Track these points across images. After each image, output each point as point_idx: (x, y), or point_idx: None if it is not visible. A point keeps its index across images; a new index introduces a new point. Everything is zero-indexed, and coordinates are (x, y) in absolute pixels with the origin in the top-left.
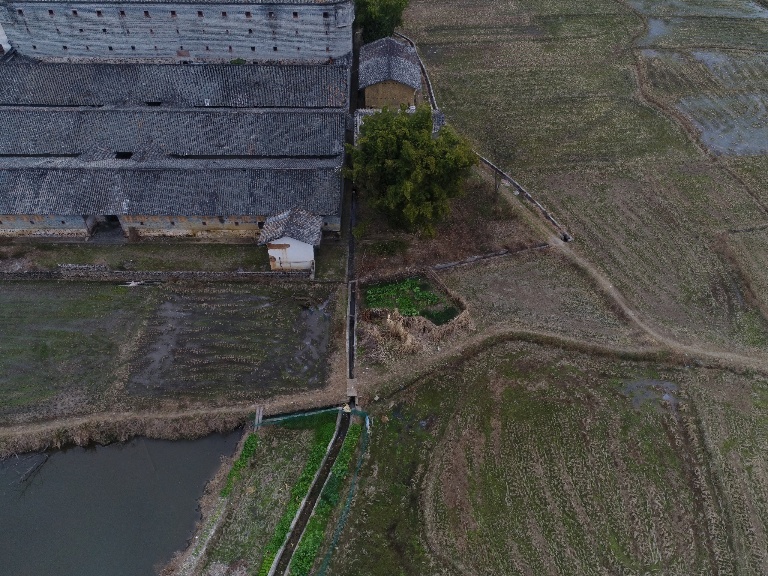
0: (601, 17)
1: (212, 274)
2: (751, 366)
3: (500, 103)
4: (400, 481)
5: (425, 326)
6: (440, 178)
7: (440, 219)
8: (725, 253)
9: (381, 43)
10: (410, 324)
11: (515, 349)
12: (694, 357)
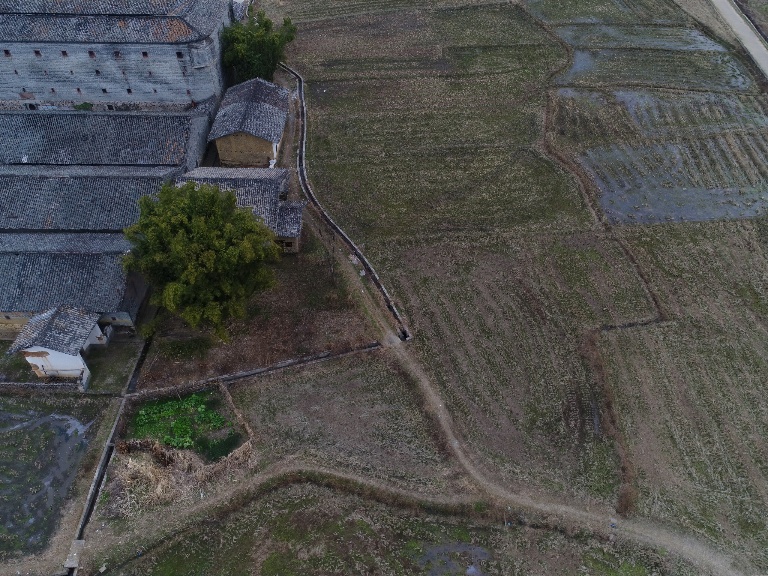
0: (523, 49)
1: None
2: (587, 526)
3: (379, 155)
4: None
5: (190, 464)
6: (235, 271)
7: (259, 310)
8: (591, 359)
9: (248, 85)
10: (174, 461)
11: (300, 495)
12: (518, 512)
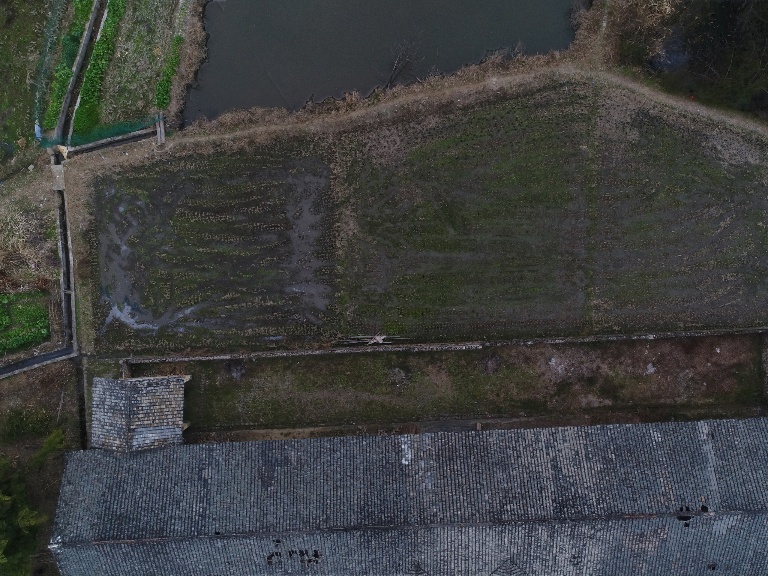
0: None
1: (267, 354)
2: None
3: None
4: (3, 68)
5: None
6: None
7: None
8: None
9: None
10: None
11: None
12: None
